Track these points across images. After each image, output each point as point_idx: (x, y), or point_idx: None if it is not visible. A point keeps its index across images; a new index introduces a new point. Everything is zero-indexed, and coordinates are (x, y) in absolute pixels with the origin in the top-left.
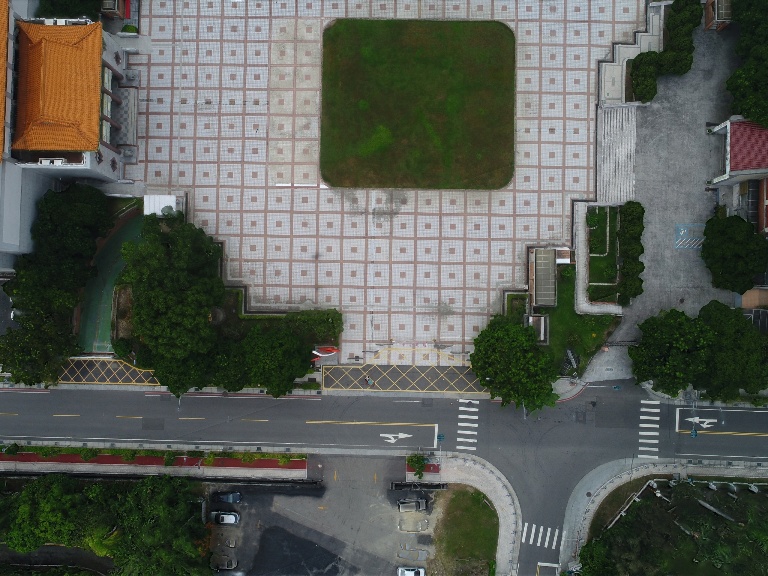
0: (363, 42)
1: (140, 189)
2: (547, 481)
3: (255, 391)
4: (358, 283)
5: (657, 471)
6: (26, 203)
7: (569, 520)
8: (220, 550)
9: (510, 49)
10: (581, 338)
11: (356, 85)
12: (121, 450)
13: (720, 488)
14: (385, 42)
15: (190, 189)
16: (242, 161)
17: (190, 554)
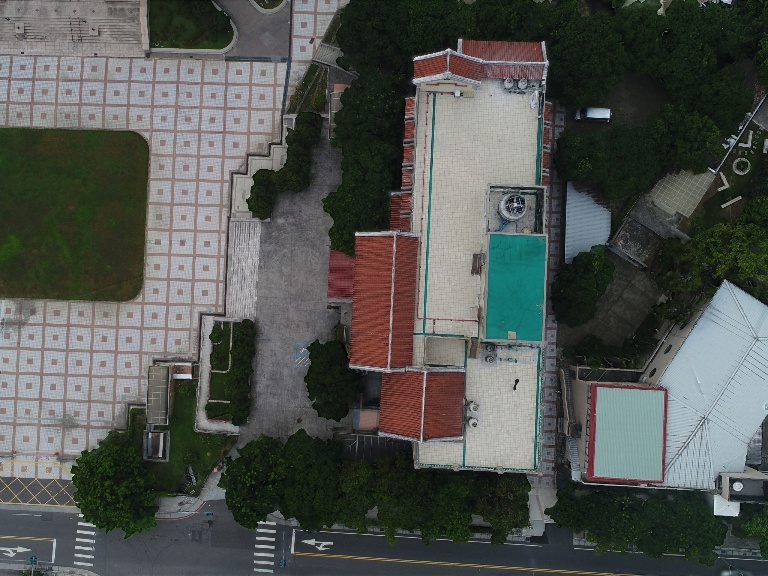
0: None
1: None
2: None
3: None
4: None
5: None
6: None
7: None
8: None
9: (143, 159)
10: (200, 455)
11: None
12: None
13: None
14: (19, 151)
15: None
16: None
17: None
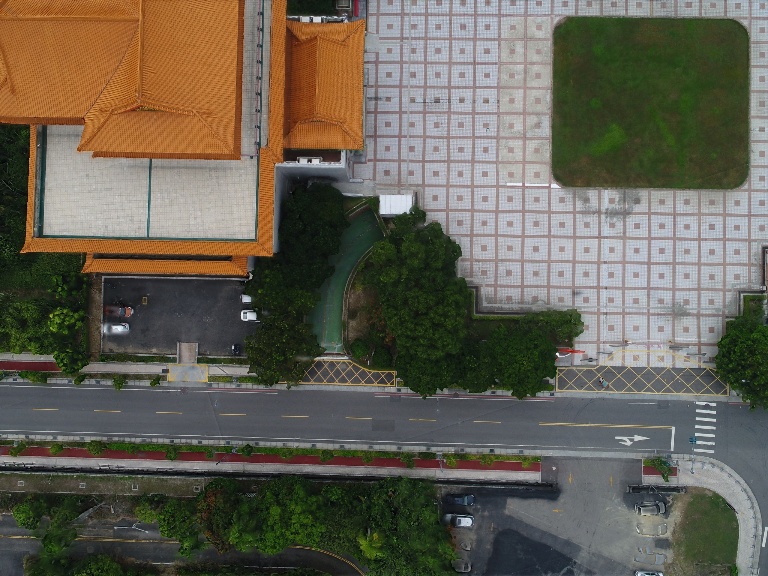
0: (594, 40)
1: (369, 188)
2: None
3: (487, 392)
4: (591, 284)
5: None
6: (277, 202)
7: None
8: (453, 553)
9: (744, 47)
10: None
11: (588, 83)
12: (353, 451)
13: None
14: (617, 40)
15: (419, 188)
16: (472, 160)
17: (450, 557)
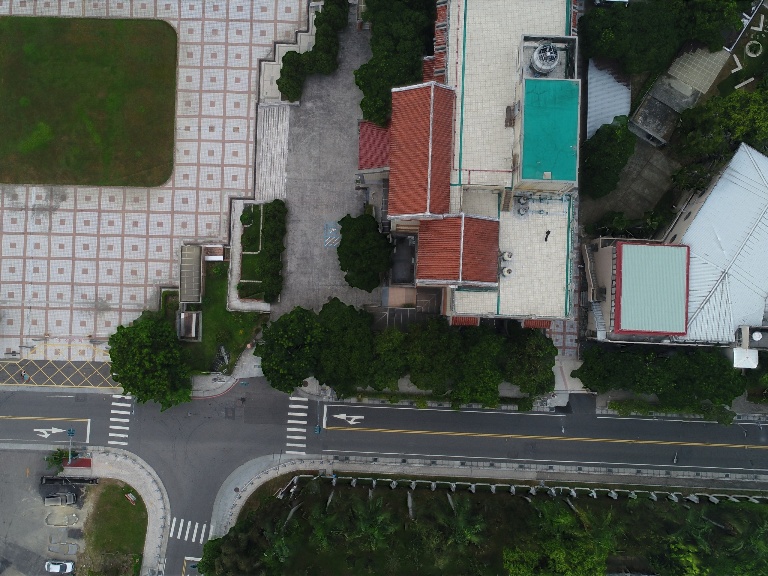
0: (26, 39)
1: None
2: (196, 476)
3: None
4: (16, 279)
5: (304, 467)
6: None
7: (217, 515)
8: None
9: (172, 47)
10: (232, 335)
11: (18, 82)
12: None
13: (363, 484)
14: (48, 39)
15: None
16: None
17: None
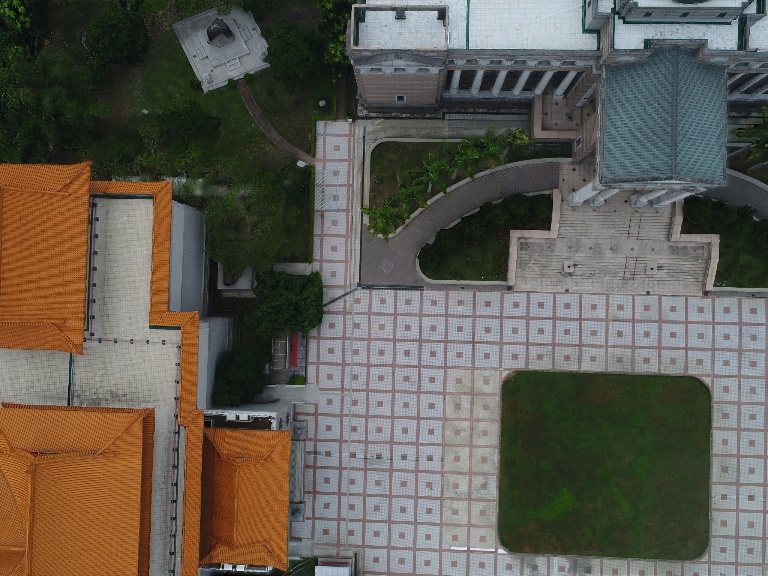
0: (545, 397)
1: (307, 548)
2: None
3: None
4: None
5: None
6: None
7: None
8: None
9: (706, 407)
10: None
11: (537, 443)
12: None
13: None
14: (569, 397)
15: (359, 549)
16: (415, 521)
17: None
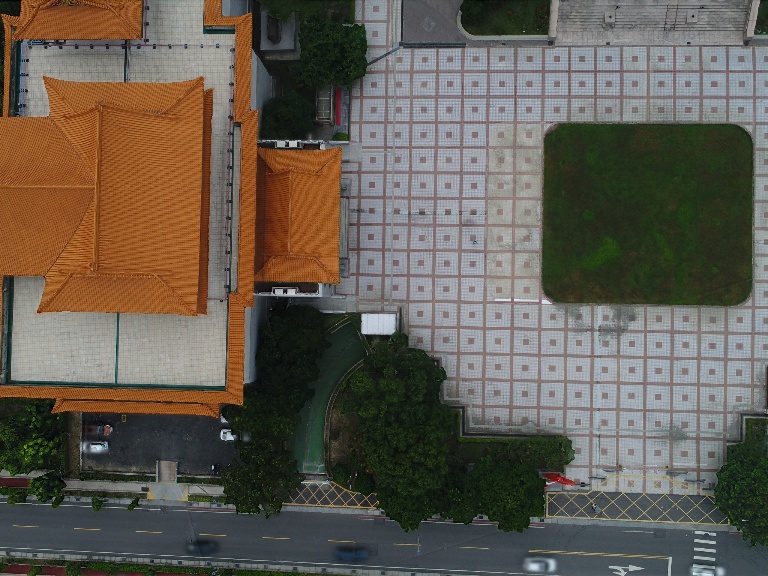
0: (587, 148)
1: (352, 304)
2: None
3: None
4: (583, 405)
5: None
6: (253, 330)
7: None
8: None
9: (747, 154)
10: None
11: (580, 194)
12: None
13: None
14: (611, 148)
15: (404, 304)
16: (459, 275)
17: None
